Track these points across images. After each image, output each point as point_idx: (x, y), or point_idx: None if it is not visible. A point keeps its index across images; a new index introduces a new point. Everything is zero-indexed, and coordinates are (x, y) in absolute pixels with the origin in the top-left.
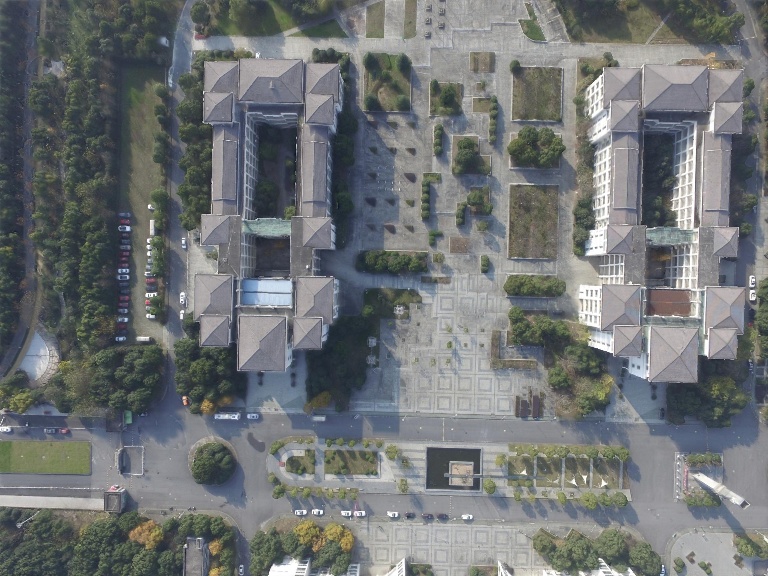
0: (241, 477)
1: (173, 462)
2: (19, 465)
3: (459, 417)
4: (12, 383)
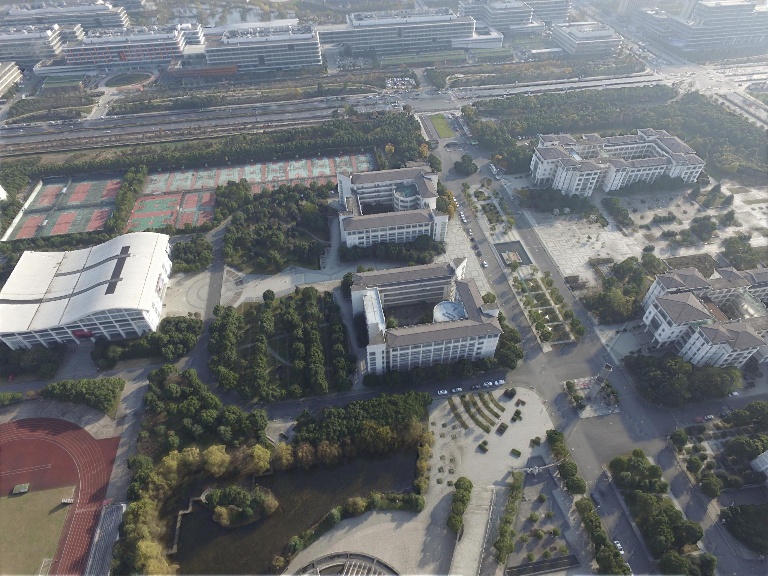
0: (463, 178)
1: (459, 158)
2: (436, 121)
3: (547, 252)
4: (476, 112)
